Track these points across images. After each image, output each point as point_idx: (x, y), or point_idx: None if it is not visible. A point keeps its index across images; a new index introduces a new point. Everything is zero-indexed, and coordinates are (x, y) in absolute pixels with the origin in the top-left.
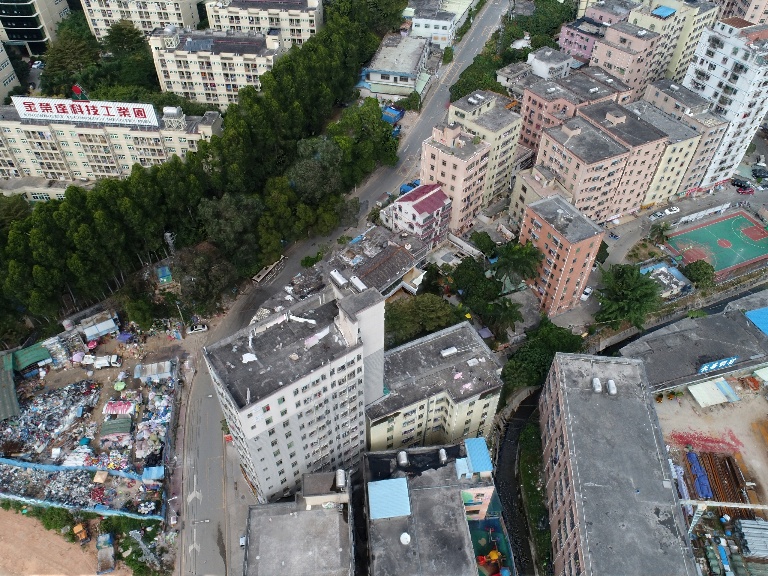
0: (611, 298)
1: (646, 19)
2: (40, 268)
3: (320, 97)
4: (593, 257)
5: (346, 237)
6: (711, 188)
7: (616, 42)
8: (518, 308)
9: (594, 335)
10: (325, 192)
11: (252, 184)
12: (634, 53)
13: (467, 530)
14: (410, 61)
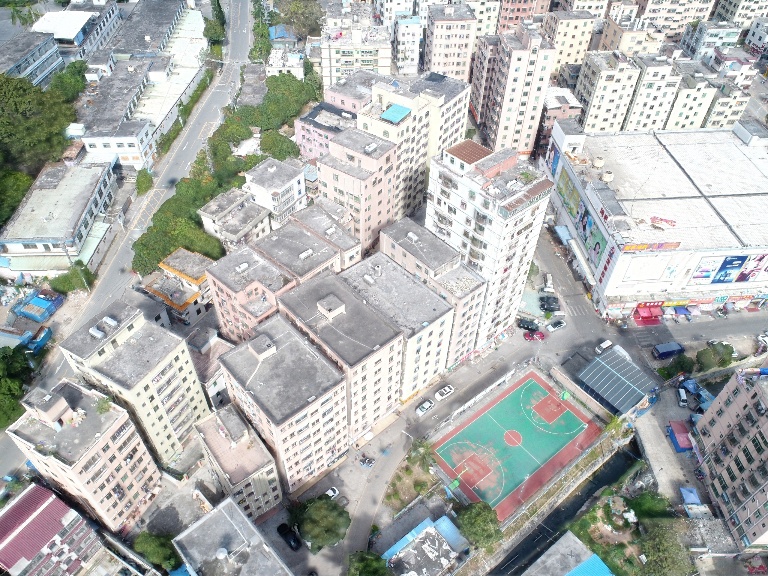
0: None
1: (376, 124)
2: None
3: None
4: None
5: None
6: None
7: (344, 159)
8: None
9: None
10: None
11: None
12: (366, 175)
13: None
14: (70, 213)
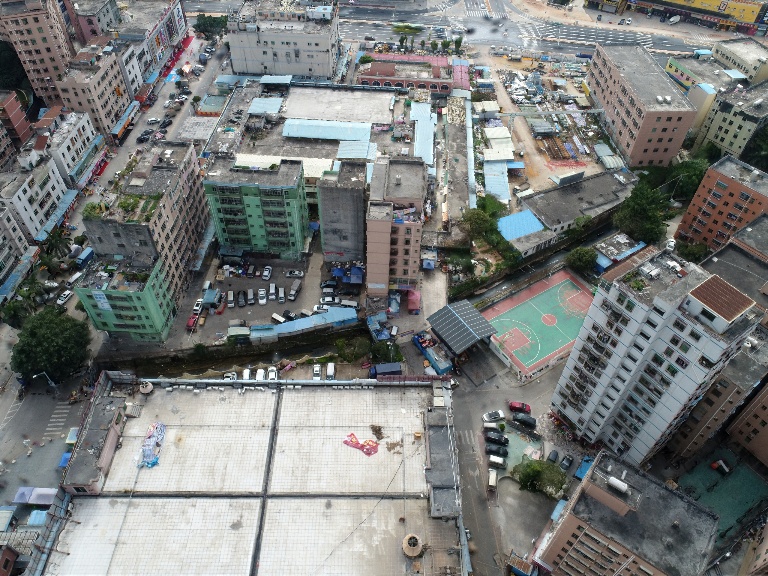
0: None
1: None
2: None
3: None
4: None
5: None
6: None
7: None
8: None
9: None
10: None
11: None
12: None
13: None
14: None
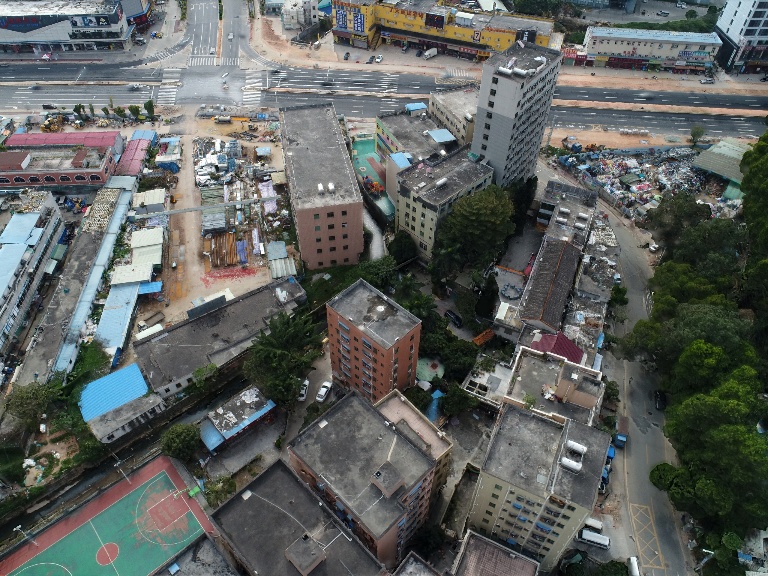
0: None
1: None
2: (761, 142)
3: None
4: None
5: None
6: None
7: None
8: None
9: None
10: None
11: (762, 324)
12: None
13: (396, 139)
14: None
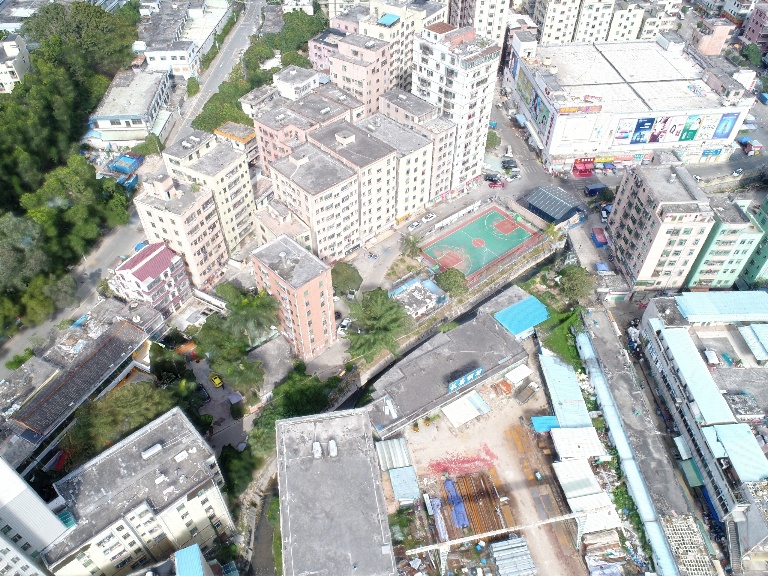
0: (362, 329)
1: (374, 28)
2: None
3: (18, 163)
4: (329, 294)
5: (65, 321)
6: (464, 187)
7: (350, 55)
8: (258, 366)
9: (353, 371)
10: (26, 276)
11: None
12: (367, 65)
13: None
14: (143, 101)
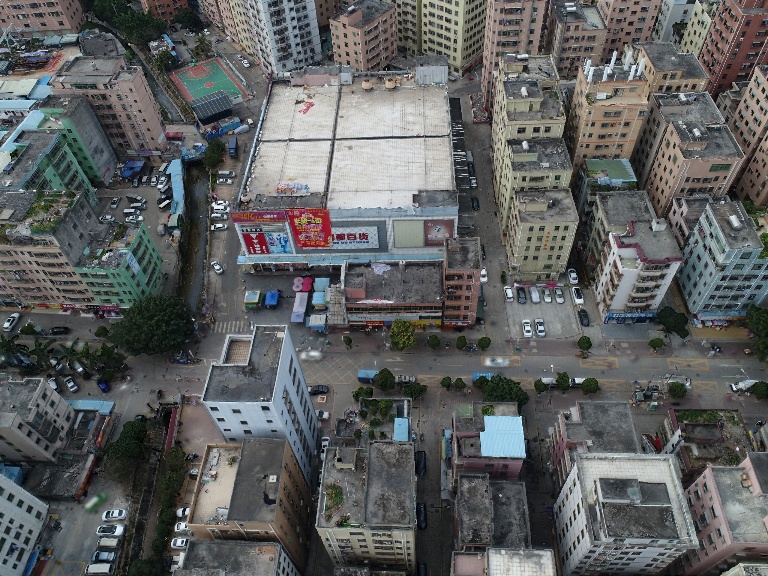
0: None
1: None
2: None
3: None
4: None
5: None
6: None
7: None
8: None
9: None
10: None
11: None
12: None
13: None
14: None
